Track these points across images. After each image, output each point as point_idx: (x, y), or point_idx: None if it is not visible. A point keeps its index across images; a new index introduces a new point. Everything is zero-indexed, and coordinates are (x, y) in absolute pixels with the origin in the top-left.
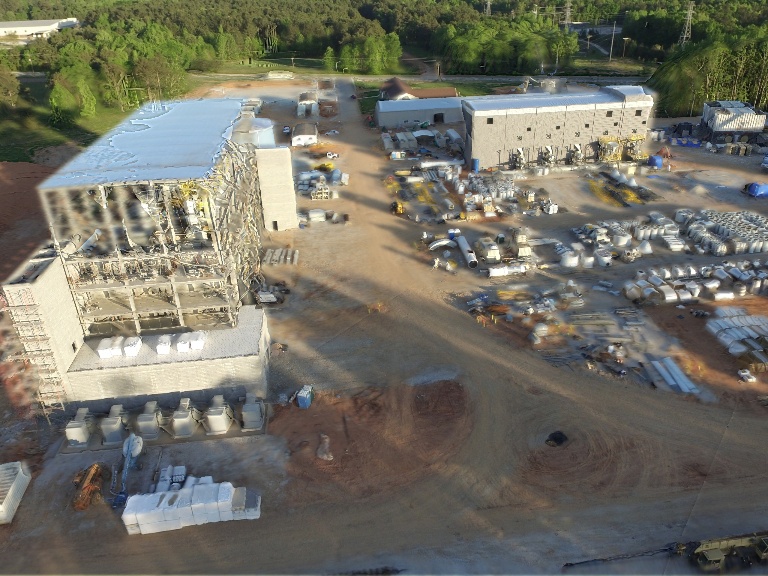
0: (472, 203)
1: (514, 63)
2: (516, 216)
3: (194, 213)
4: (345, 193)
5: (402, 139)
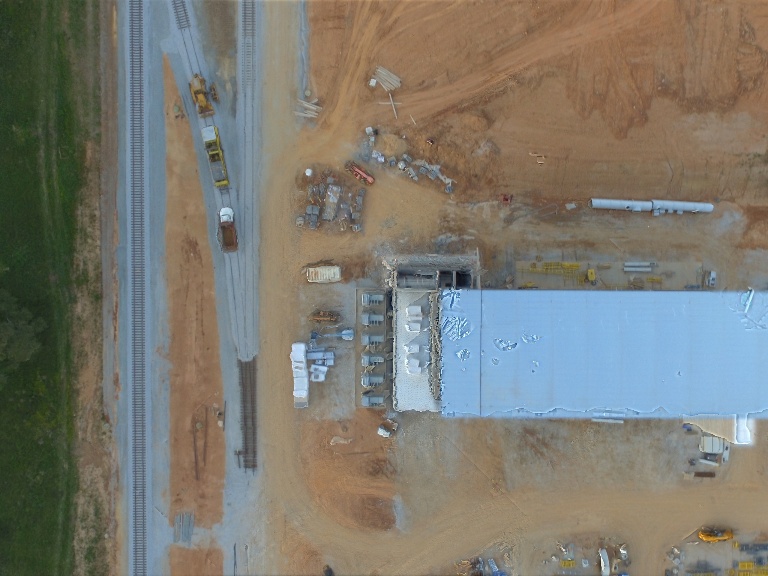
0: None
1: None
2: None
3: None
4: None
5: None
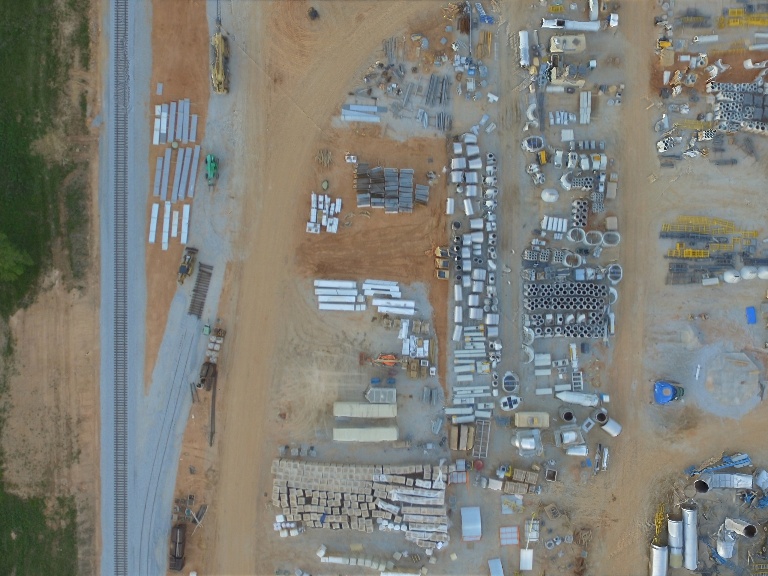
0: (700, 63)
1: None
2: (659, 105)
3: None
4: None
5: None
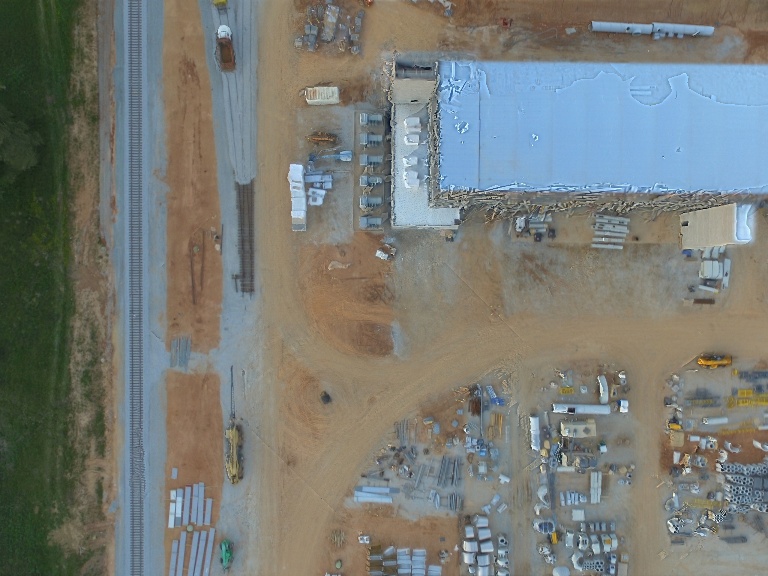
0: (710, 446)
1: None
2: (669, 483)
3: None
4: None
5: None
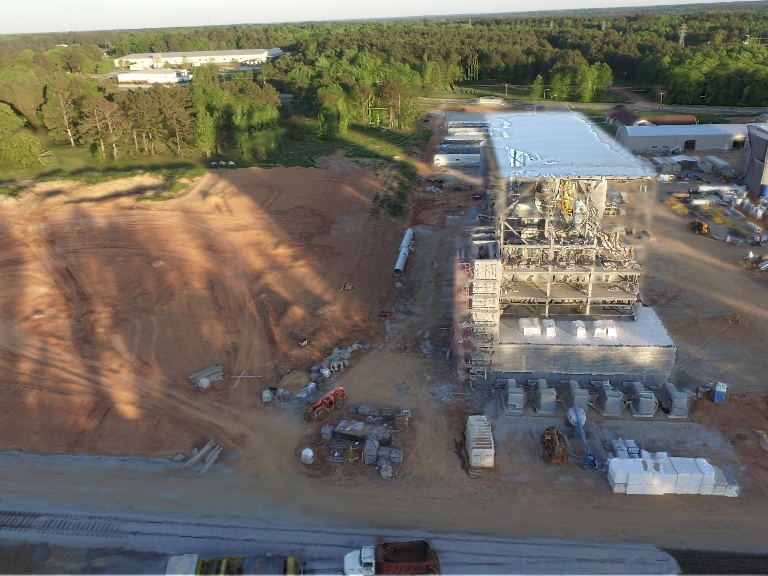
0: None
1: (739, 94)
2: None
3: (567, 214)
4: (629, 211)
5: (664, 163)
